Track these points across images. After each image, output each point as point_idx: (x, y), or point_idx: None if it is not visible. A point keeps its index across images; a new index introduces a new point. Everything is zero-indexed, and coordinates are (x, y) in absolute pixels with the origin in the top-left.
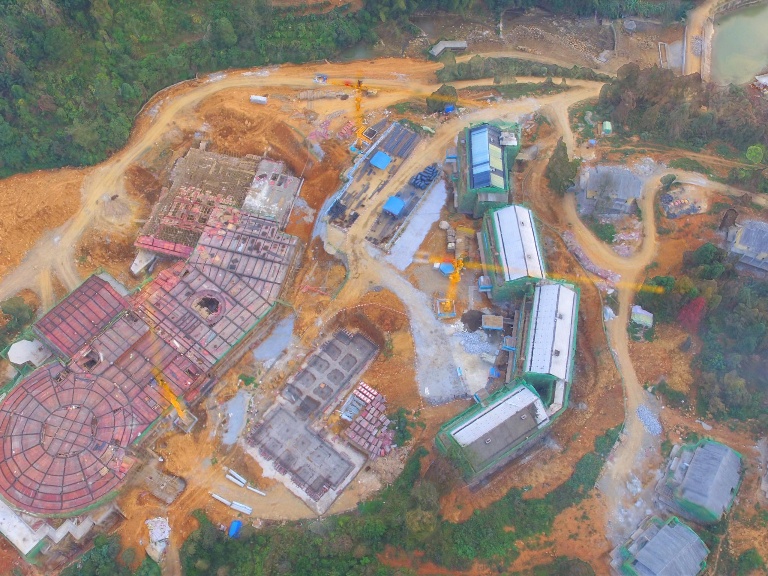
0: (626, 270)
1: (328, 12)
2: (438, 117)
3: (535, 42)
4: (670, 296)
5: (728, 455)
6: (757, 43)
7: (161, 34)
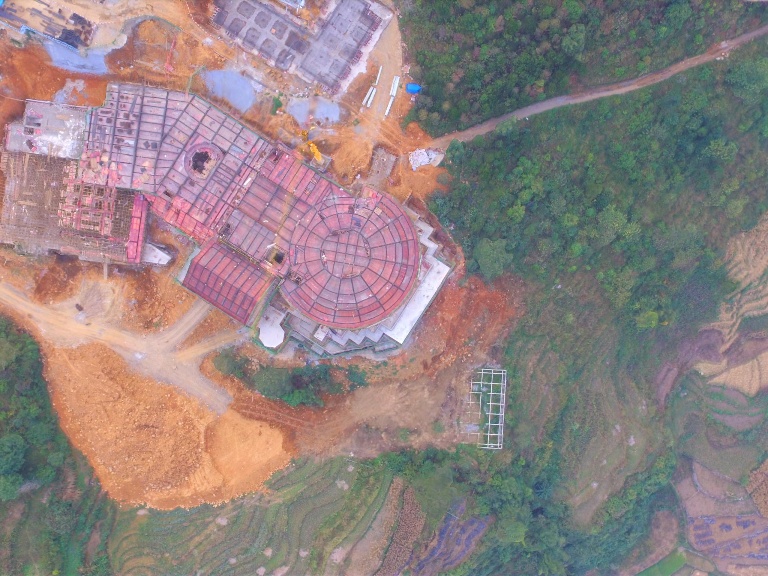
0: None
1: None
2: None
3: None
4: None
5: None
6: None
7: None
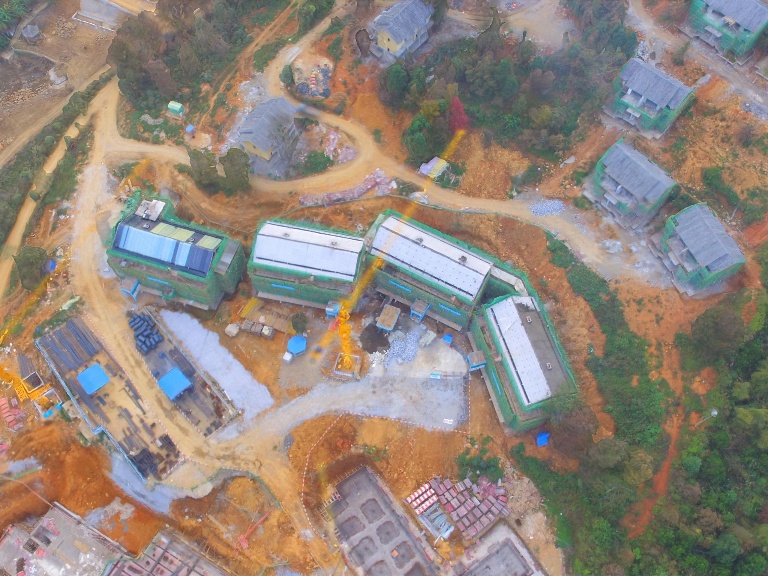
0: (373, 161)
1: None
2: (56, 285)
3: None
4: (436, 128)
5: (622, 148)
6: None
7: None
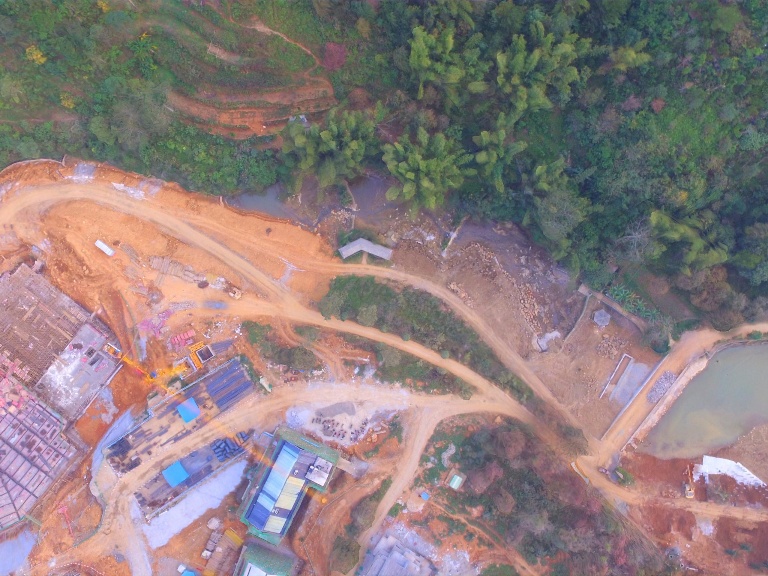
0: None
1: (242, 139)
2: (285, 371)
3: (480, 281)
4: None
5: None
6: (745, 408)
7: (22, 103)
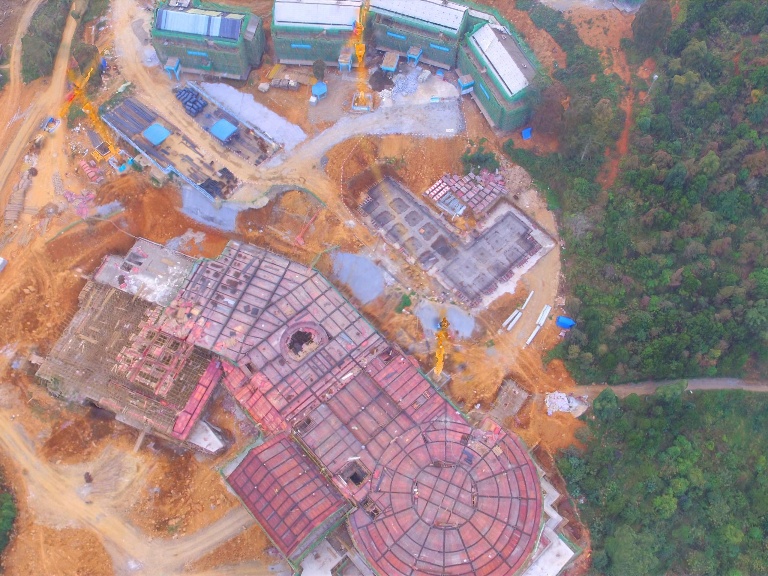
0: None
1: None
2: (109, 76)
3: None
4: None
5: None
6: None
7: None
